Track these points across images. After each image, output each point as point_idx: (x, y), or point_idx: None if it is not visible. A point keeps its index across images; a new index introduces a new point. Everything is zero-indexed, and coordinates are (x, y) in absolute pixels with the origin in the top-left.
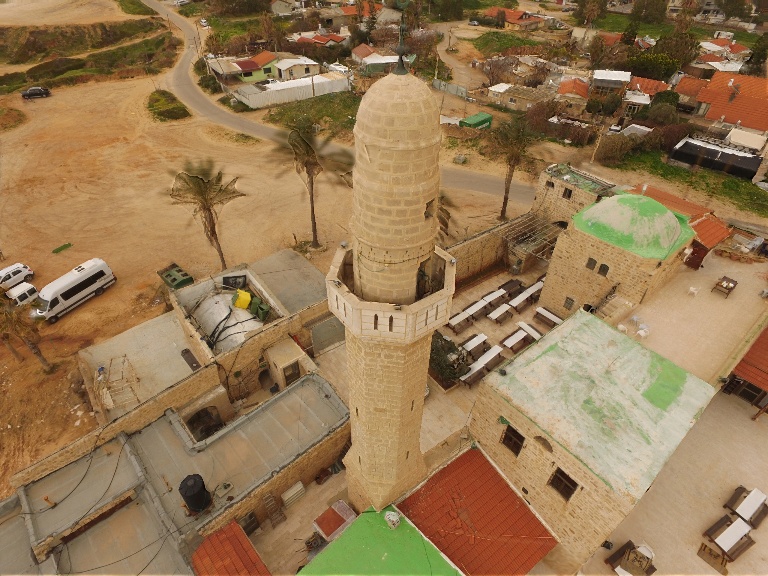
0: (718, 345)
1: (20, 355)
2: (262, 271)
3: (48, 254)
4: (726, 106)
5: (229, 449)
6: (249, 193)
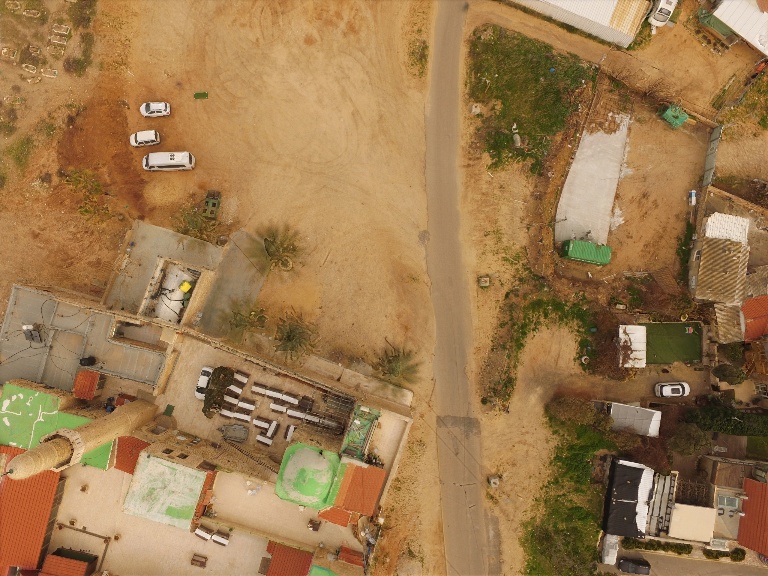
0: (266, 525)
1: (117, 196)
2: (245, 250)
3: (191, 95)
4: (765, 499)
5: (116, 351)
6: (336, 149)
